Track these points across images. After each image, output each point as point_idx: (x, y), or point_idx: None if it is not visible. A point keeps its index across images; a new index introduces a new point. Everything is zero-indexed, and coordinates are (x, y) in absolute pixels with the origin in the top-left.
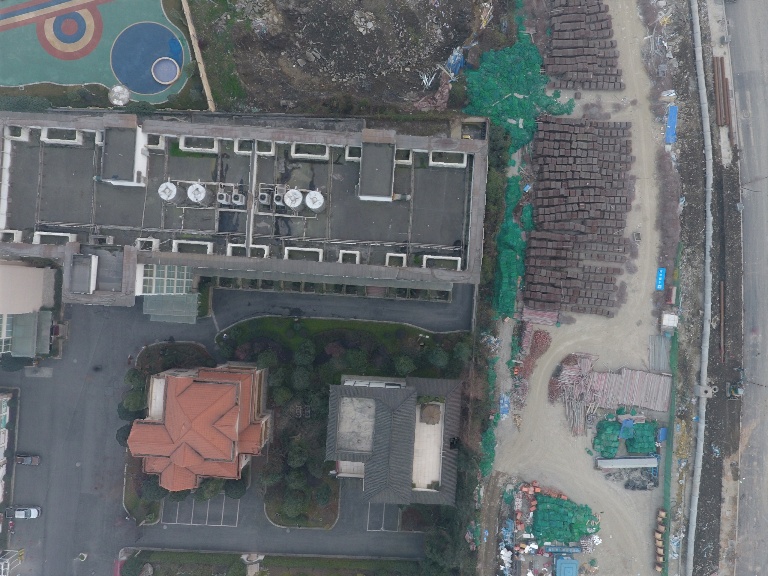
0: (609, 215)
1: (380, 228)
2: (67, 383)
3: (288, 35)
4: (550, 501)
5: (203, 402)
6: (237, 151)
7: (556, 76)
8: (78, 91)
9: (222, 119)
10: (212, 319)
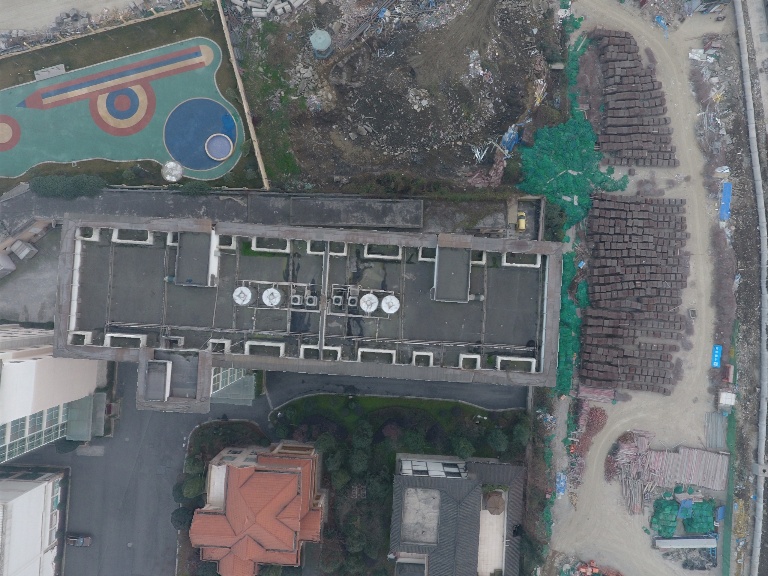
0: (665, 292)
1: (453, 328)
2: (119, 462)
3: (341, 110)
4: None
5: (266, 494)
6: (310, 252)
7: (610, 152)
8: (132, 168)
9: (278, 199)
10: (265, 397)
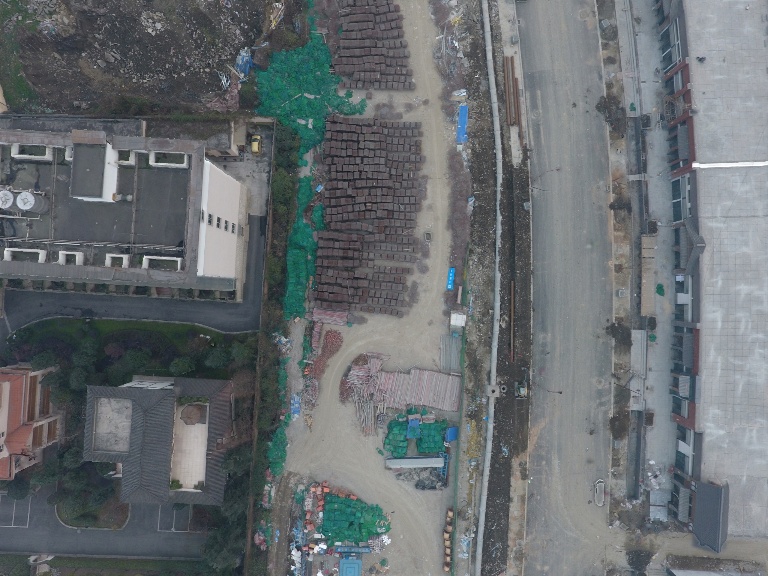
0: (398, 215)
1: (105, 229)
2: None
3: (85, 36)
4: (339, 501)
5: None
6: None
7: (348, 76)
8: None
9: (4, 120)
10: (4, 320)
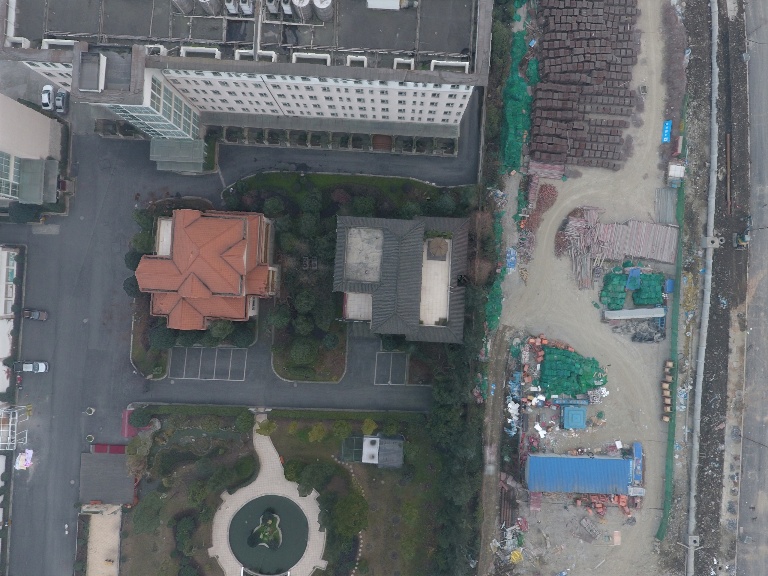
0: (615, 67)
1: (387, 37)
2: (74, 240)
3: None
4: (557, 353)
5: (211, 233)
6: None
7: None
8: None
9: None
10: (218, 175)
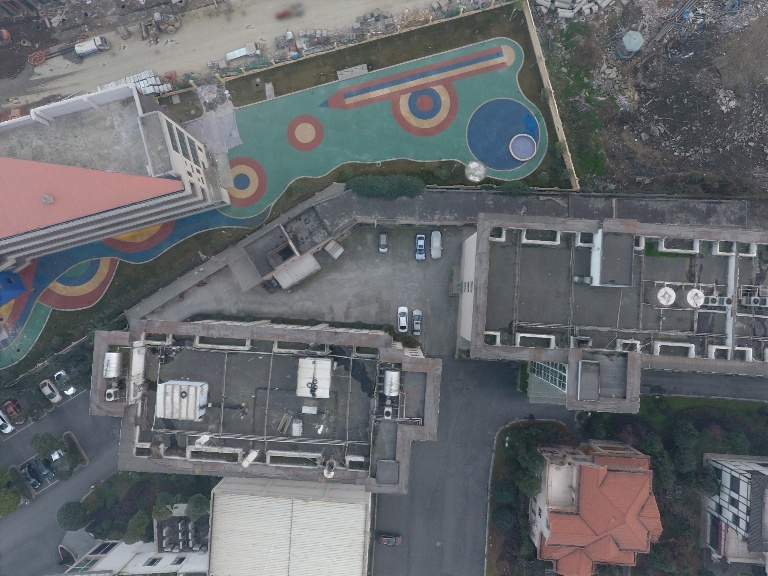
0: None
1: None
2: (426, 461)
3: (637, 110)
4: None
5: (627, 493)
6: (721, 253)
7: None
8: None
9: (598, 199)
10: None
